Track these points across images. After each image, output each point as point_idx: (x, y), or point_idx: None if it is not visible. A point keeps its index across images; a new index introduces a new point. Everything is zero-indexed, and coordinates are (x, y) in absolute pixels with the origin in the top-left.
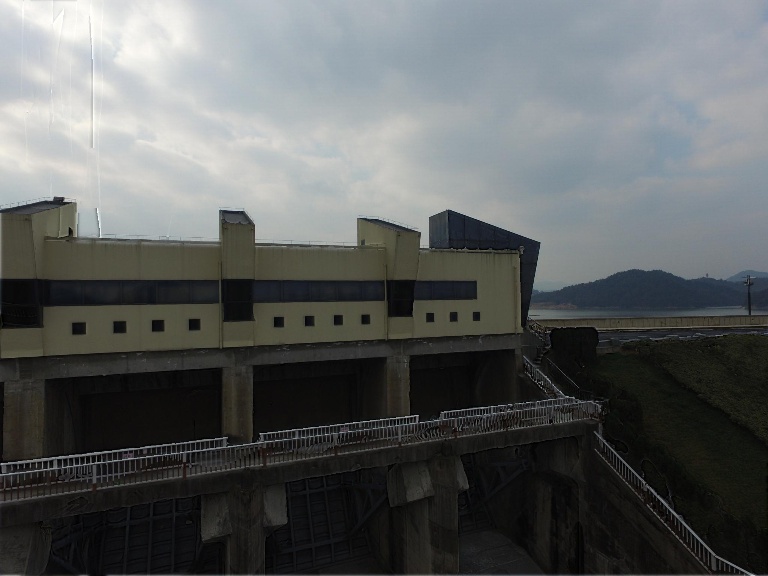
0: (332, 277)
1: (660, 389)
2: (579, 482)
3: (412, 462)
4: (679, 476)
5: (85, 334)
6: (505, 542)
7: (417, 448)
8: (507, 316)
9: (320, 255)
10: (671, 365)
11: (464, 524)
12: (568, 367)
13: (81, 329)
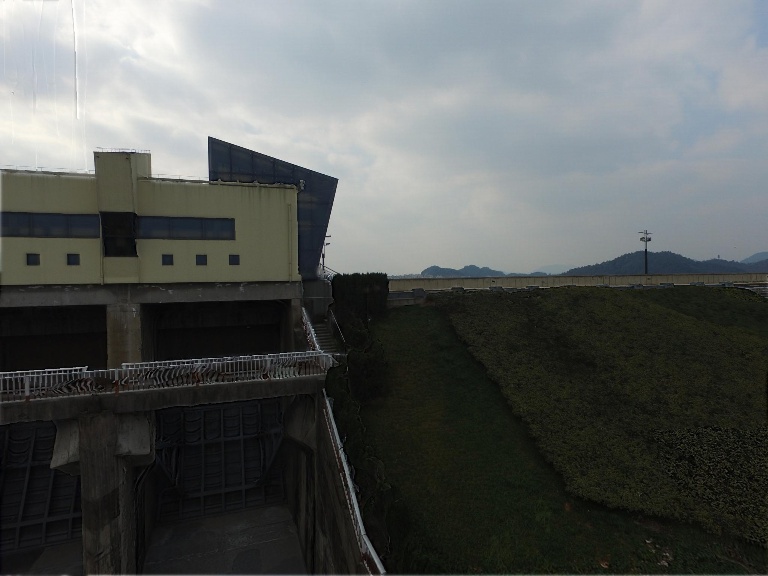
0: (24, 208)
1: (434, 342)
2: (313, 449)
3: (65, 422)
4: (352, 437)
5: None
6: (284, 518)
7: (54, 404)
8: (279, 261)
9: (5, 181)
10: (459, 316)
11: (251, 498)
12: (343, 319)
13: None
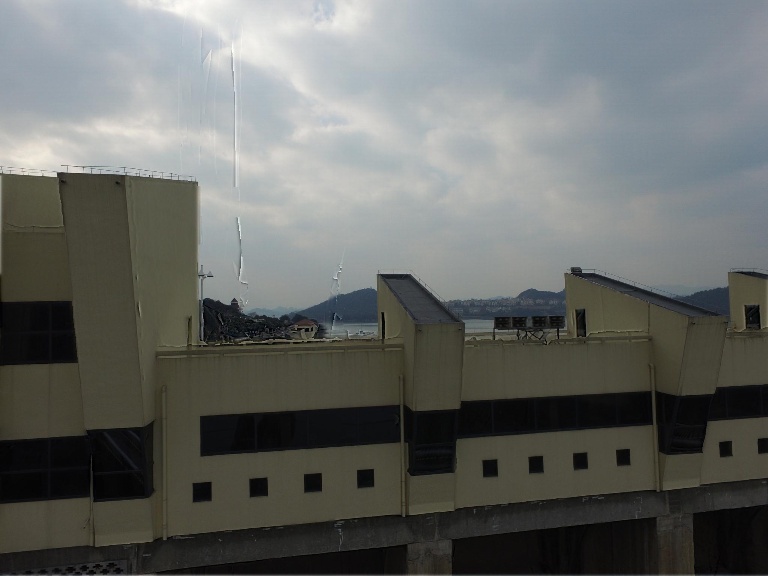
0: None
1: None
2: None
3: None
4: None
5: (731, 456)
6: None
7: None
8: None
9: None
10: None
11: None
12: None
13: (726, 449)
